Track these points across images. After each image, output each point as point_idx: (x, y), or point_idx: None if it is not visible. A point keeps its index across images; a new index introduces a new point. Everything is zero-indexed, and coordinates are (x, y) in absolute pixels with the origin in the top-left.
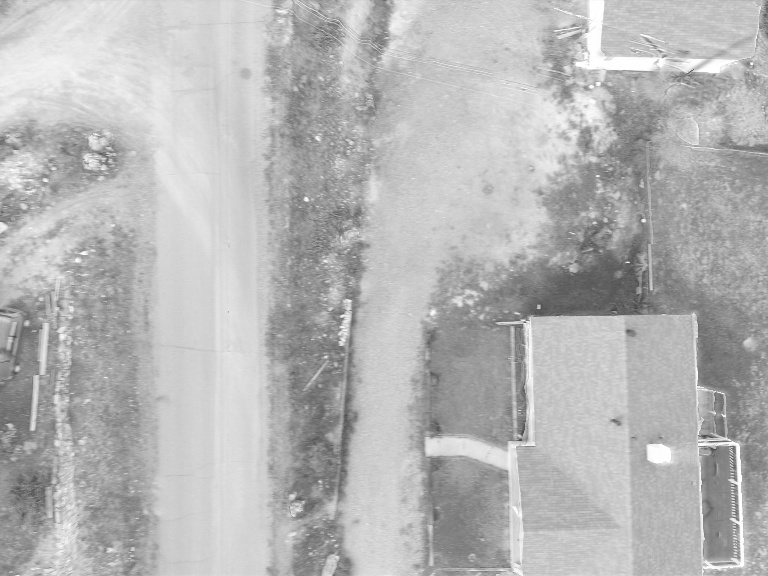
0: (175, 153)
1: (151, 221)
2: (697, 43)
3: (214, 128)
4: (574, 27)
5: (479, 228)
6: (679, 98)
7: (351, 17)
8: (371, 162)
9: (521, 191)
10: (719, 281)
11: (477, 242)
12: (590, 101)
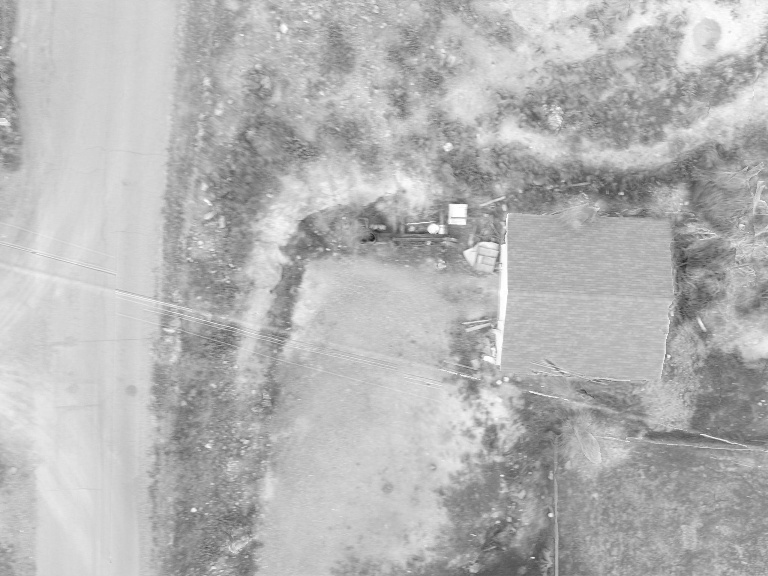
0: (57, 469)
1: (31, 536)
2: (601, 366)
3: (98, 444)
4: (483, 320)
5: (377, 528)
6: (591, 392)
7: (248, 317)
8: (267, 458)
9: (421, 490)
10: (629, 572)
11: (374, 542)
12: (496, 399)
